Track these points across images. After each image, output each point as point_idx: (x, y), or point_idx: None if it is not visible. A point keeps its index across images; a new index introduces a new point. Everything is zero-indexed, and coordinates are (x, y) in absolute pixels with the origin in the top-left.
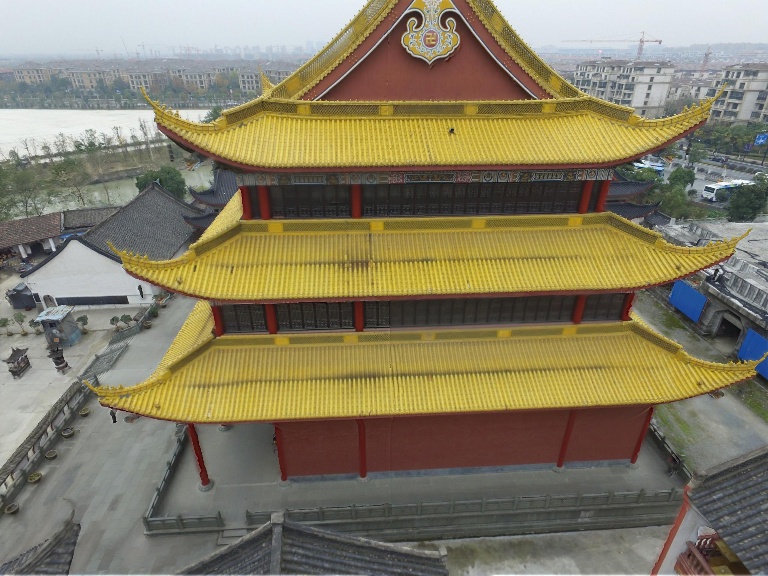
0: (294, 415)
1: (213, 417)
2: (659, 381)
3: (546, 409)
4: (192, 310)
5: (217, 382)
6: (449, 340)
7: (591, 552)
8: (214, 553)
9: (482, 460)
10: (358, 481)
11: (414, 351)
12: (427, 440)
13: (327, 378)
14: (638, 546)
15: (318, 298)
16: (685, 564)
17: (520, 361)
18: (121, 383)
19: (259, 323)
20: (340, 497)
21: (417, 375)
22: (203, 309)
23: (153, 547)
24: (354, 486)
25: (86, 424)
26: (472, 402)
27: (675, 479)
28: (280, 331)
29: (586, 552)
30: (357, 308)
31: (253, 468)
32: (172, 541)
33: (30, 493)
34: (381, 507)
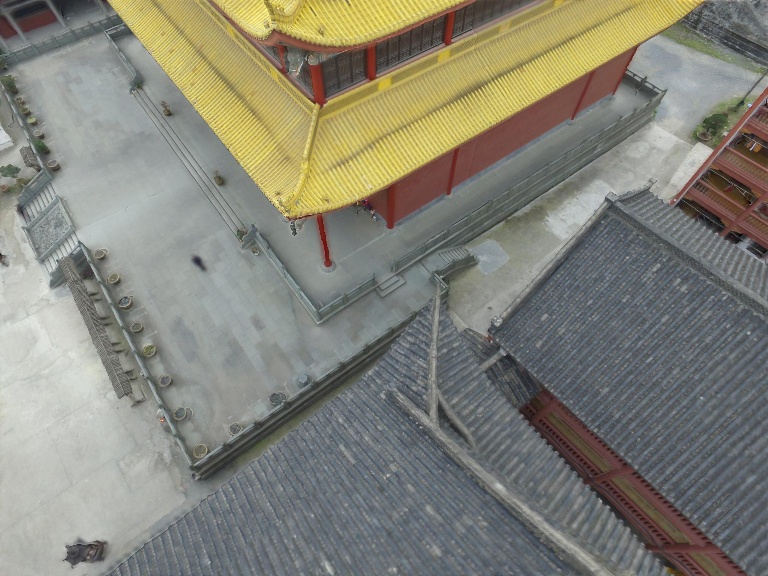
0: (441, 151)
1: (375, 186)
2: (668, 6)
3: (609, 61)
4: (192, 102)
5: (351, 153)
6: (519, 25)
7: (607, 170)
8: (565, 249)
9: (529, 137)
10: (446, 199)
11: (496, 48)
12: (499, 137)
13: (443, 105)
14: (629, 152)
15: (455, 6)
16: (754, 123)
17: (576, 25)
18: (112, 236)
19: (358, 71)
20: (443, 217)
21: (511, 71)
22: (211, 95)
23: (332, 328)
24: (445, 205)
25: (130, 288)
26: (561, 77)
27: (640, 95)
28: (378, 73)
29: (604, 171)
30: (450, 14)
31: (353, 234)
32: (343, 316)
33: (161, 364)
34: (487, 205)
